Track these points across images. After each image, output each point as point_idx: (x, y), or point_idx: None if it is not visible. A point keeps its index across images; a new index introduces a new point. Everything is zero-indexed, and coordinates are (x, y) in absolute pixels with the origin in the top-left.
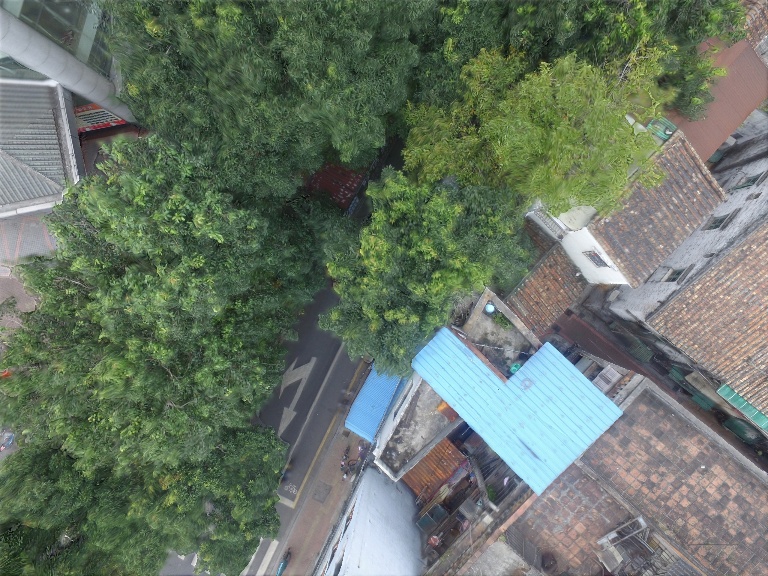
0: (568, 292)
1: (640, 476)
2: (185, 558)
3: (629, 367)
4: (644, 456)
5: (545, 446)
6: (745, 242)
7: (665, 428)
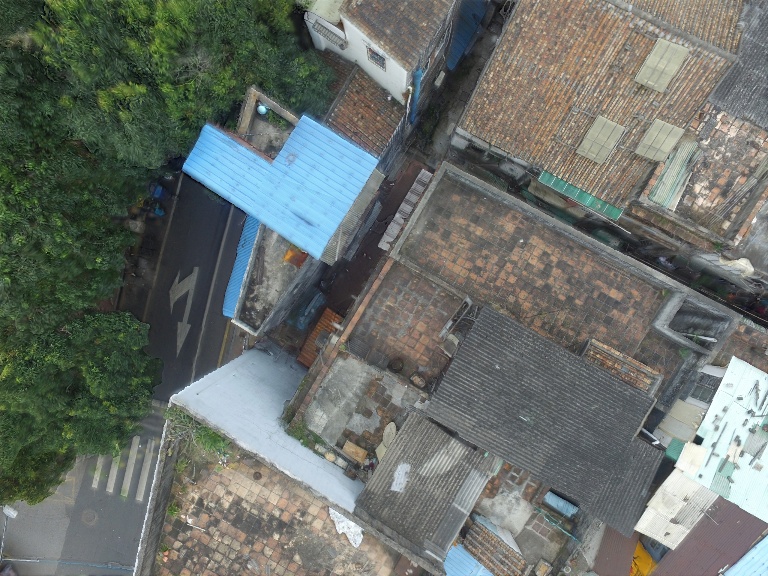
0: (386, 119)
1: (466, 264)
2: (113, 490)
3: None
4: (466, 244)
5: (316, 212)
6: (516, 14)
7: (480, 212)
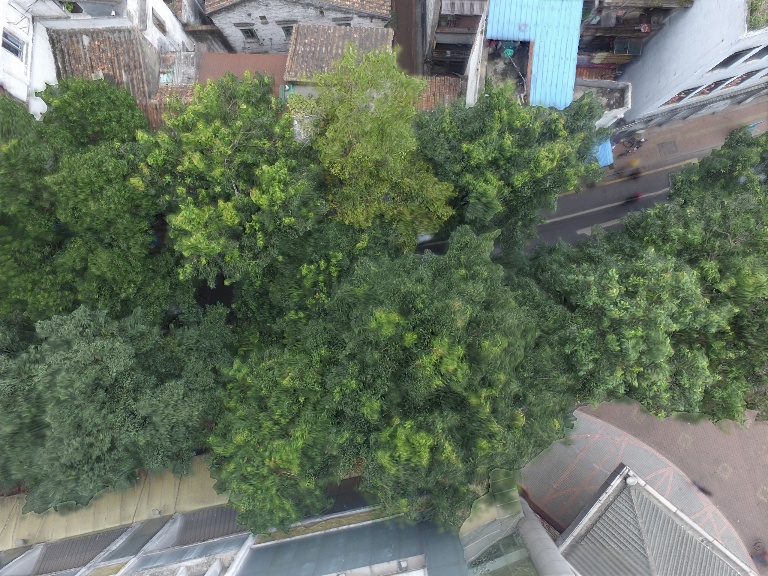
0: None
1: None
2: None
3: (401, 24)
4: None
5: None
6: None
7: None
